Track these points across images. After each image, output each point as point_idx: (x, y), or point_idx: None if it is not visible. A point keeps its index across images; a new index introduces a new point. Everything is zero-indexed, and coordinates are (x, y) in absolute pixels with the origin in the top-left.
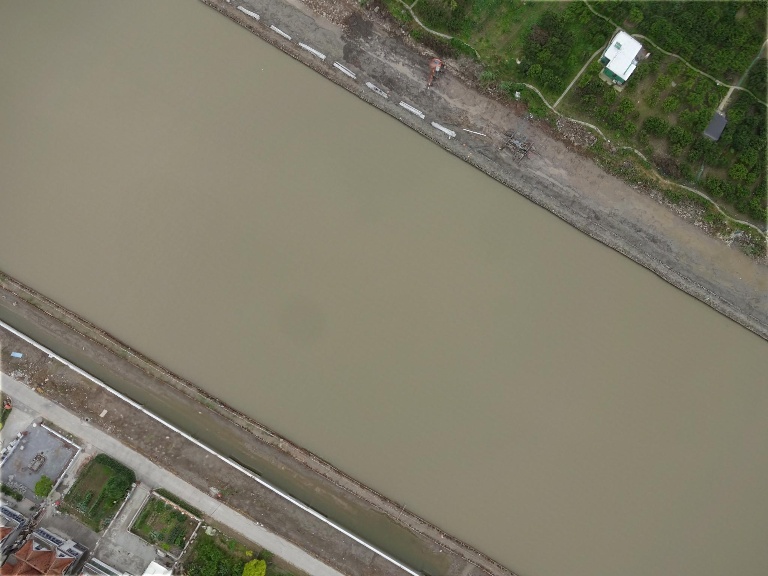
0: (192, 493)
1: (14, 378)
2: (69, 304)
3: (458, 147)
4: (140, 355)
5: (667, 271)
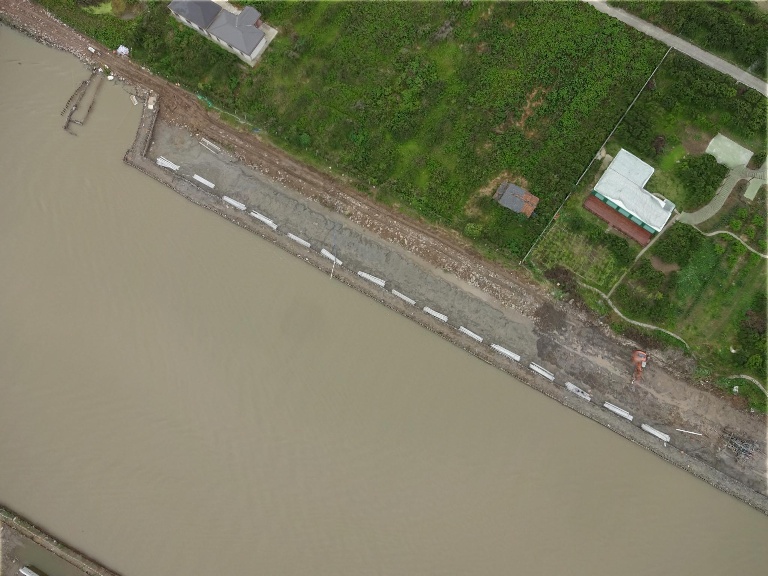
0: None
1: None
2: None
3: (676, 456)
4: None
5: None
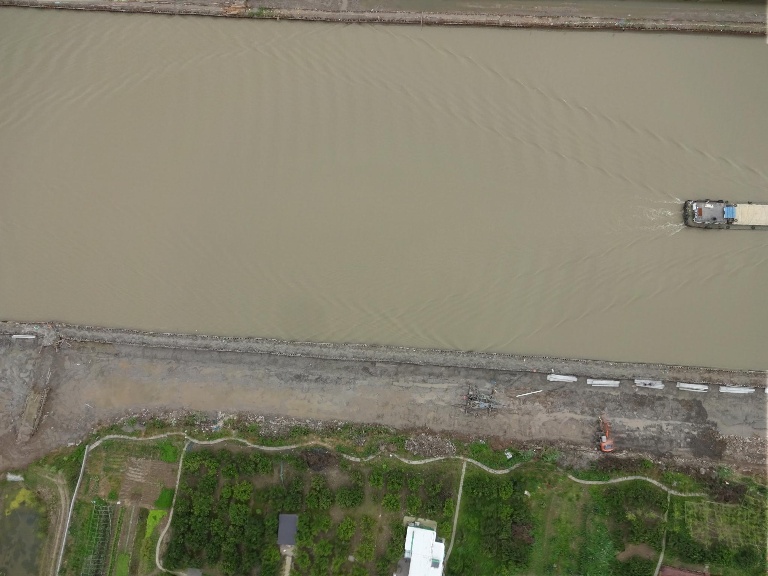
0: None
1: None
2: None
3: (540, 365)
4: (709, 30)
5: (275, 348)
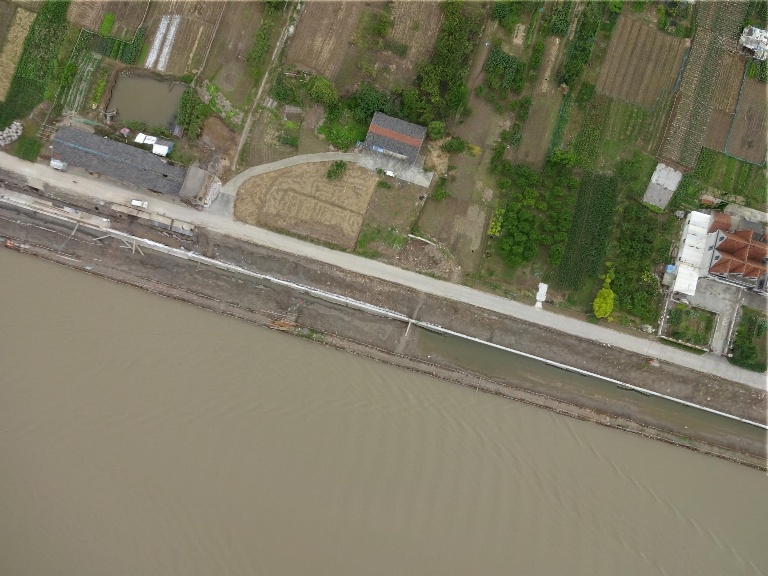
0: (674, 357)
1: None
2: None
3: None
4: (760, 469)
5: None
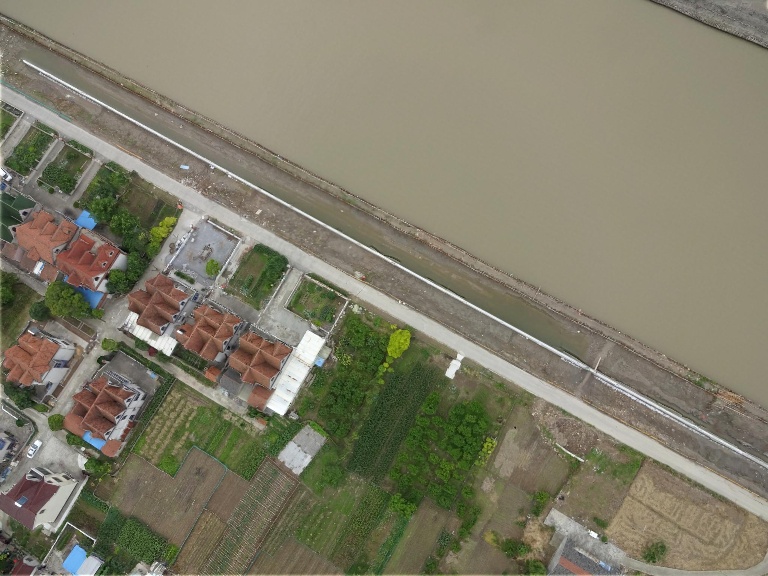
0: (339, 276)
1: (184, 184)
2: (226, 123)
3: None
4: (288, 161)
5: None
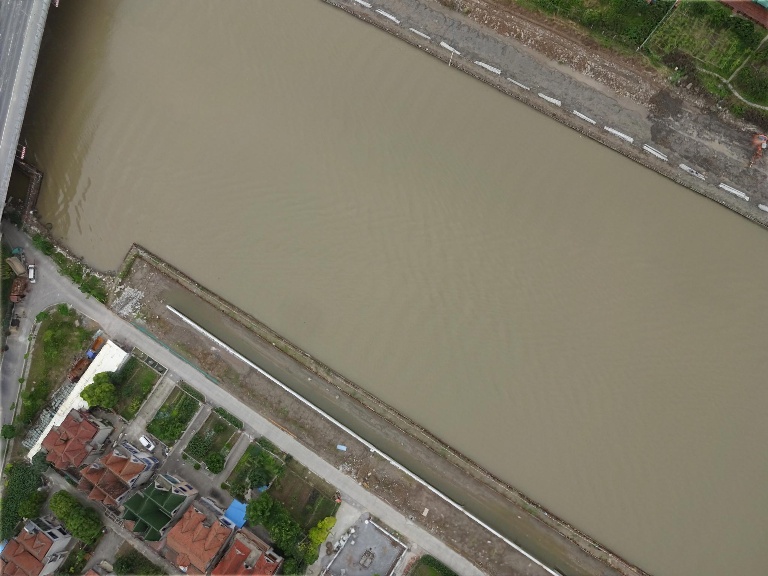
0: None
1: (342, 472)
2: (388, 399)
3: None
4: (459, 454)
5: None
